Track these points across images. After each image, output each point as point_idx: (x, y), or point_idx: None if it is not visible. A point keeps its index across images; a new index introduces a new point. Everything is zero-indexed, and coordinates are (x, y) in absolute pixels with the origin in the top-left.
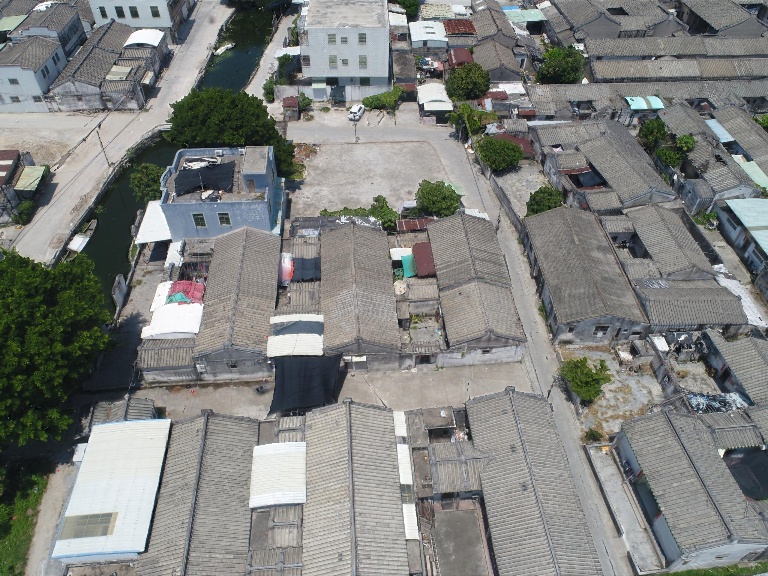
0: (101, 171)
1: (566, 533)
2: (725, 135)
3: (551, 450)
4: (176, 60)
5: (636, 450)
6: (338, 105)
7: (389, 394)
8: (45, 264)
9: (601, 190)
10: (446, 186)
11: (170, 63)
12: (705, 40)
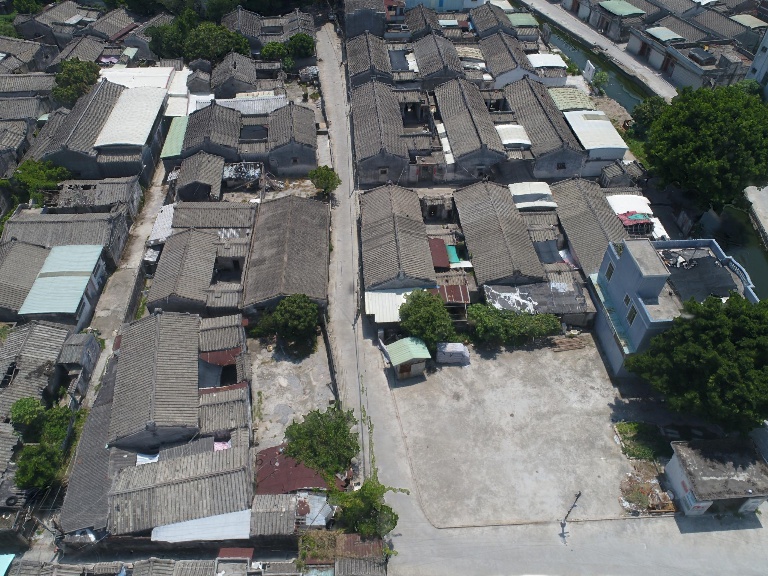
0: None
1: None
2: None
3: None
4: None
5: (315, 138)
6: None
7: None
8: None
9: (214, 337)
10: (415, 324)
11: None
12: None
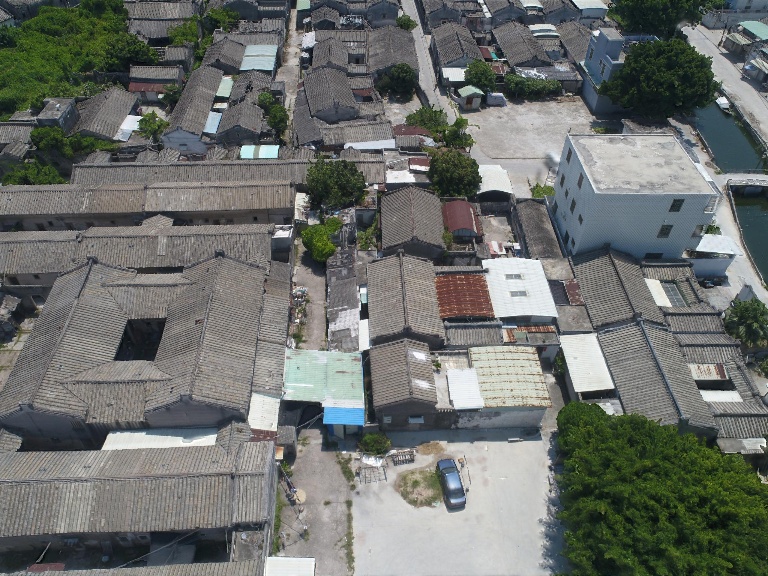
0: None
1: None
2: (213, 117)
3: None
4: None
5: None
6: None
7: None
8: (722, 83)
9: (357, 82)
10: (475, 75)
11: None
12: None
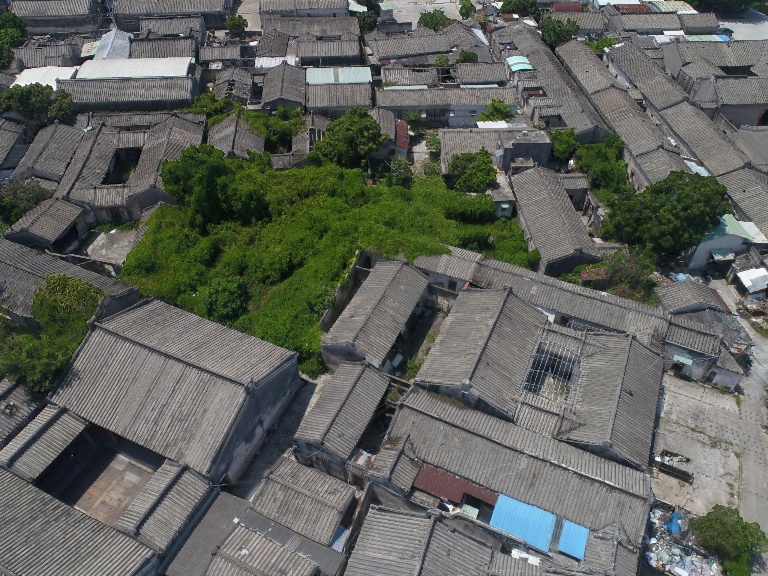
0: None
1: (163, 4)
2: None
3: (197, 6)
4: None
5: None
6: None
7: (251, 6)
8: None
9: None
10: None
11: None
12: (685, 105)
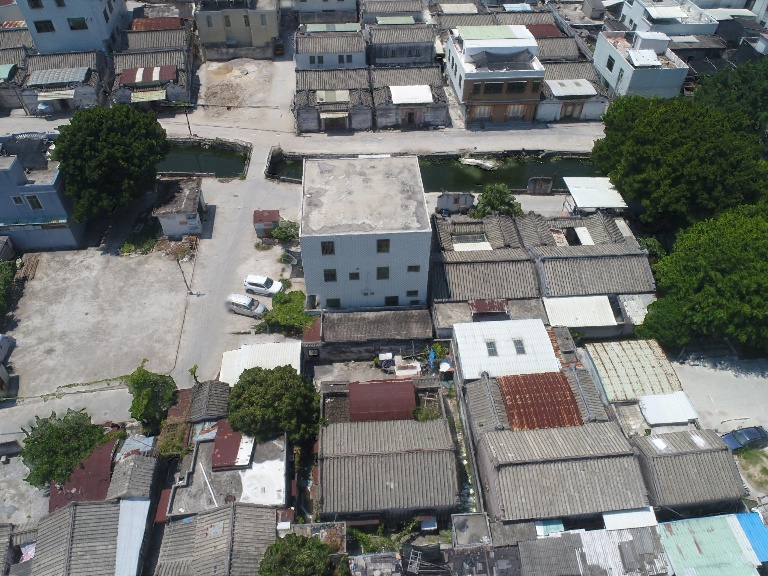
0: (186, 133)
1: None
2: None
3: None
4: (423, 133)
5: None
6: (298, 270)
7: None
8: None
9: None
10: None
11: (415, 131)
12: None
